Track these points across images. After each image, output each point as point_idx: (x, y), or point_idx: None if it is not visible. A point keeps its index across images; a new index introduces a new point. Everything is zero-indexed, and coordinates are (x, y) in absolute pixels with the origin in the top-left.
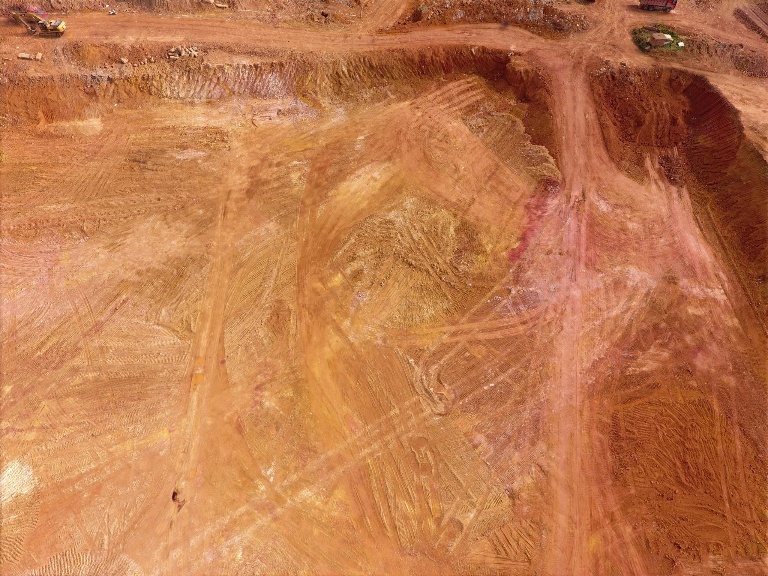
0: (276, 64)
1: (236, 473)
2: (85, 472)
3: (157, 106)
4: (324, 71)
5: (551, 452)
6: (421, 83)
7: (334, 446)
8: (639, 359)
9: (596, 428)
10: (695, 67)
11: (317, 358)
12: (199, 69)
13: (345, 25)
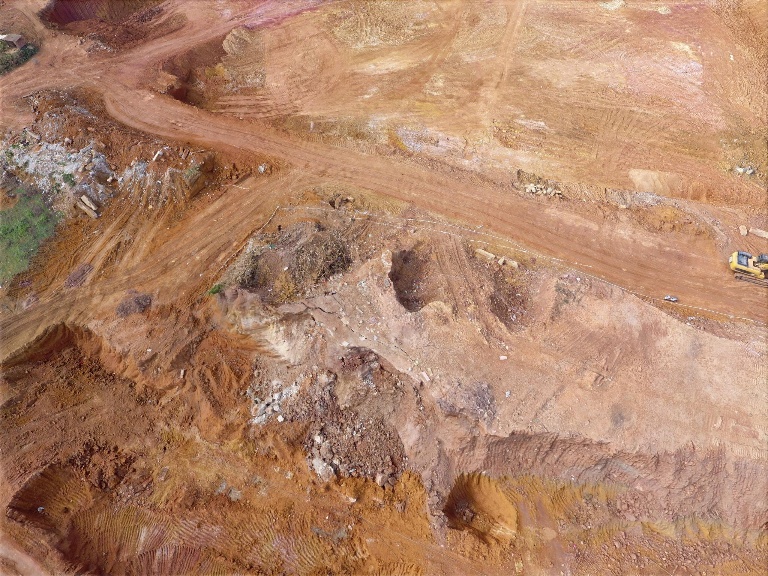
0: None
1: None
2: (575, 1)
3: None
4: None
5: None
6: None
7: None
8: None
9: None
10: (29, 20)
11: (456, 3)
12: None
13: None
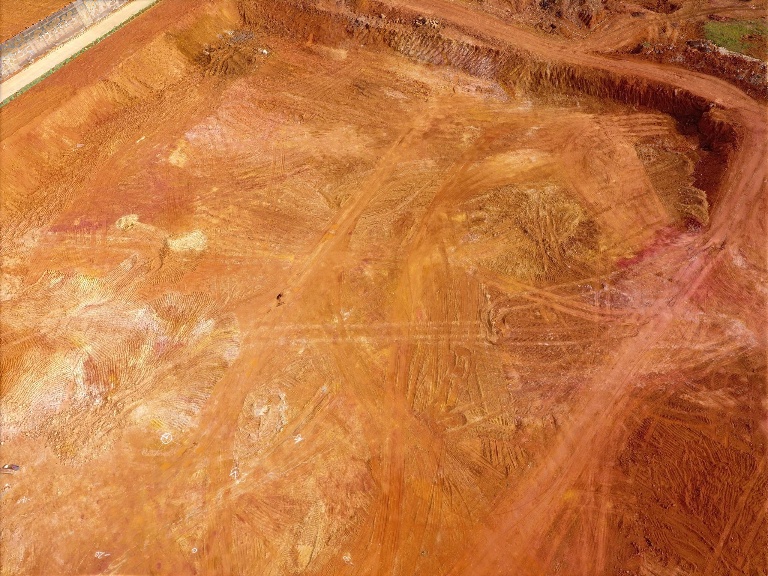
0: (493, 51)
1: (324, 303)
2: (235, 256)
3: (390, 56)
4: (530, 68)
5: (571, 415)
6: (612, 105)
7: (399, 321)
8: (700, 393)
9: (624, 420)
10: None
11: (417, 261)
12: (433, 37)
13: (567, 39)
